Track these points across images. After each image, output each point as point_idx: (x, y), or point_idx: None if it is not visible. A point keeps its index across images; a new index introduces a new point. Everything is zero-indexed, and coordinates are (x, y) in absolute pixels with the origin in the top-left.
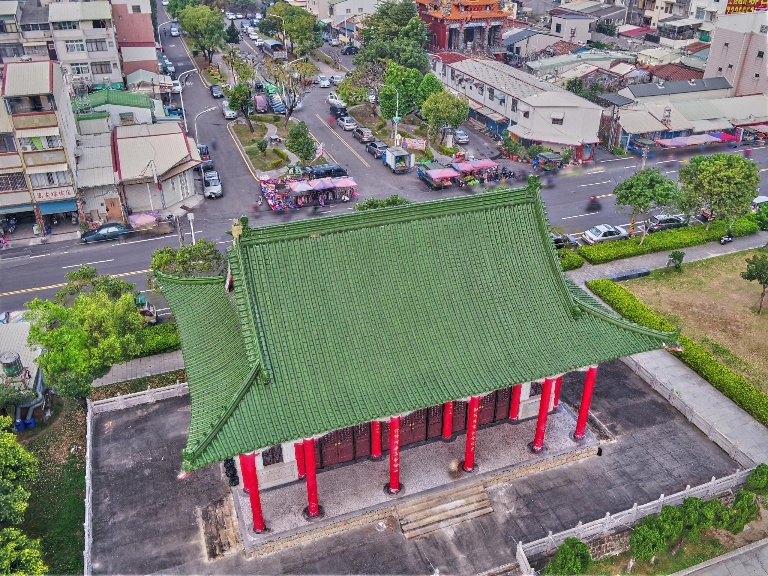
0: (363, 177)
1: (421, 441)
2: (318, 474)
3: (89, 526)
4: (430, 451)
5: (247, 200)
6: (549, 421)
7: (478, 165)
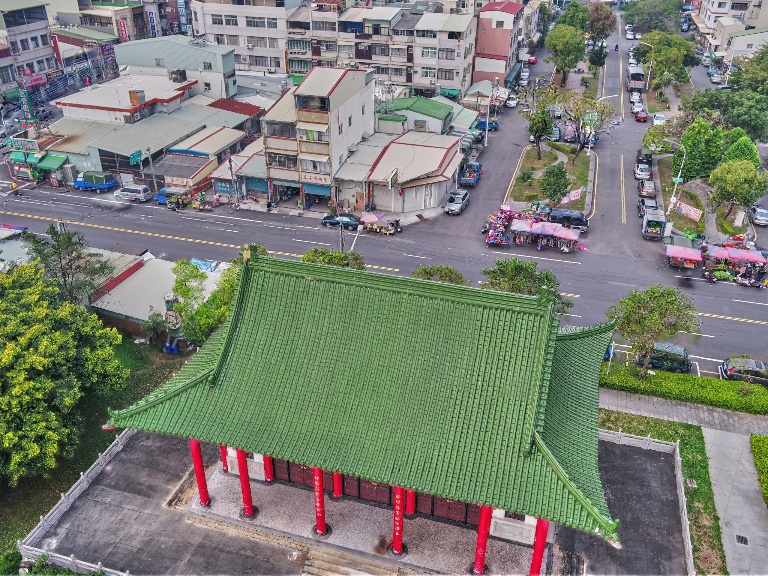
0: (607, 232)
1: (384, 504)
2: (282, 485)
3: (123, 438)
4: (382, 516)
5: (477, 224)
6: (518, 552)
7: (736, 255)
